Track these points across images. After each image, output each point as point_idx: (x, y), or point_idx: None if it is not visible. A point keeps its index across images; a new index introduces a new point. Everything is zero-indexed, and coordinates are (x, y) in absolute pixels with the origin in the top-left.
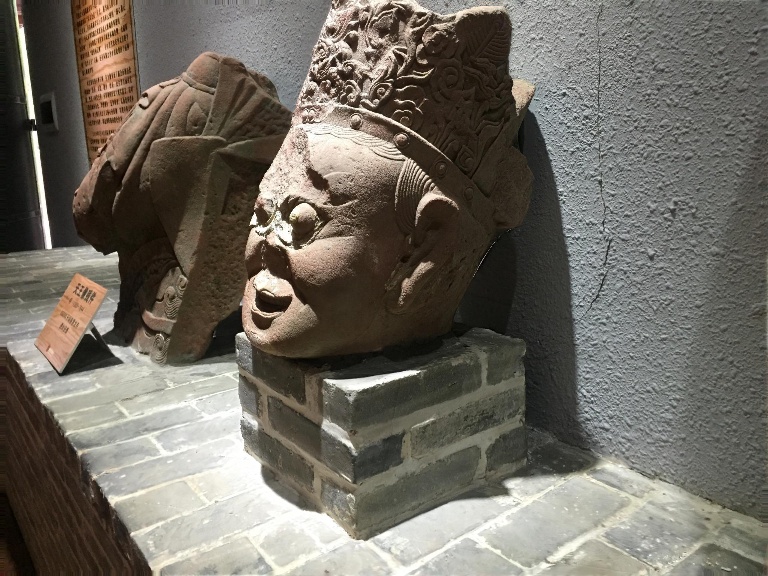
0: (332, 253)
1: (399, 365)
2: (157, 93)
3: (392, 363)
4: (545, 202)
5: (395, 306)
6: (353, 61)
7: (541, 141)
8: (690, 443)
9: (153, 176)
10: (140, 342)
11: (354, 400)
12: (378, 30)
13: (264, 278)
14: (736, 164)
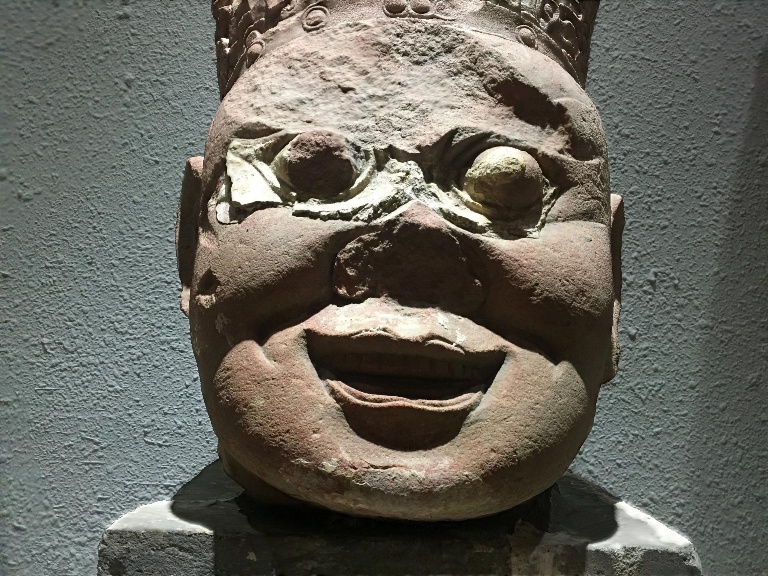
0: (599, 249)
1: None
2: None
3: None
4: None
5: (609, 375)
6: None
7: None
8: (703, 556)
9: None
10: None
11: None
12: None
13: (394, 315)
14: (714, 234)
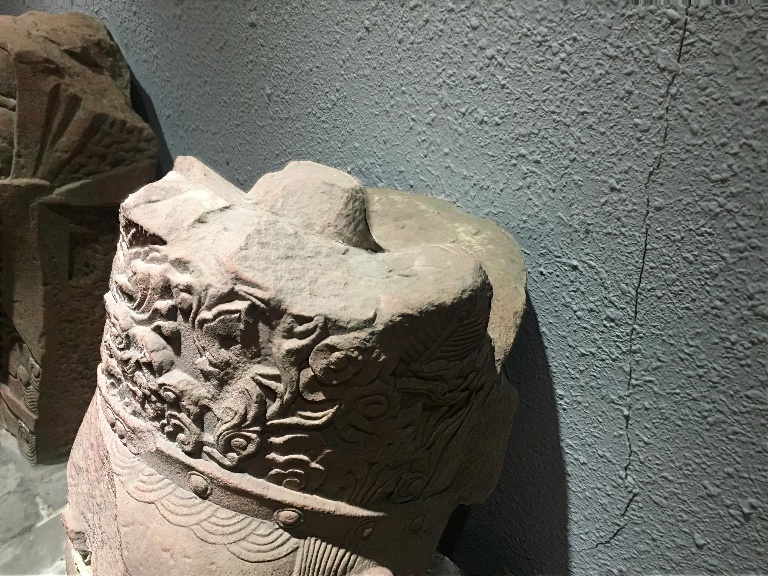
0: None
1: None
2: None
3: None
4: (534, 394)
5: None
6: (175, 383)
7: (531, 314)
8: None
9: None
10: (3, 415)
11: None
12: (216, 336)
13: None
14: None
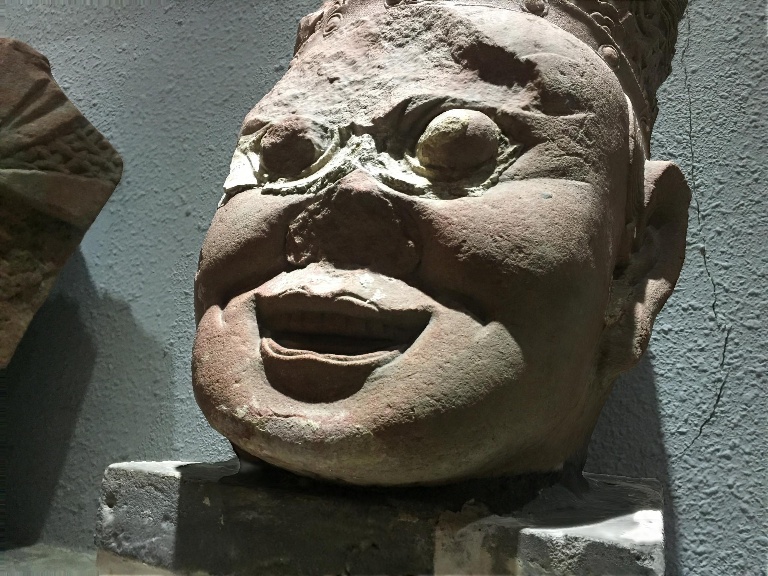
0: (560, 205)
1: None
2: None
3: (581, 501)
4: None
5: (626, 358)
6: None
7: None
8: None
9: None
10: None
11: (664, 572)
12: None
13: (322, 276)
14: None
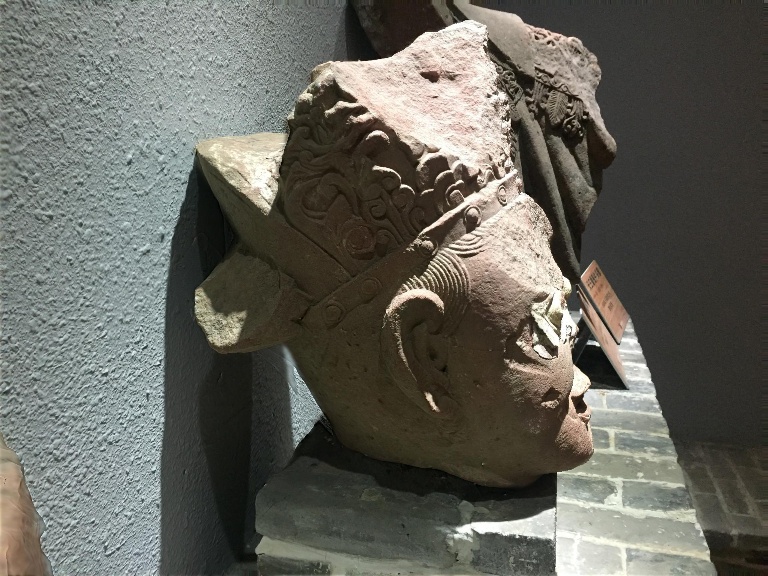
0: None
1: None
2: None
3: None
4: None
5: None
6: None
7: None
8: None
9: None
10: None
11: None
12: None
13: None
14: None
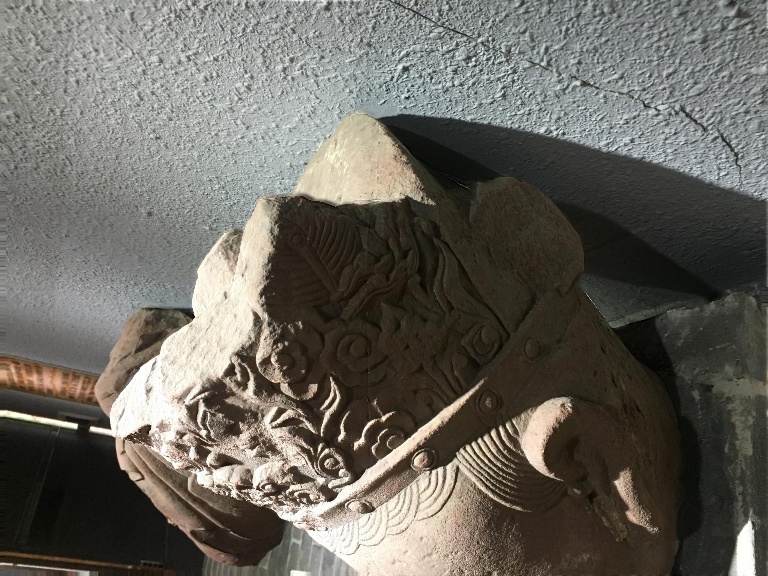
0: None
1: (713, 527)
2: (129, 461)
3: (703, 532)
4: (540, 153)
5: None
6: (259, 479)
7: (450, 123)
8: None
9: (230, 504)
10: None
11: None
12: (225, 435)
13: None
14: None
